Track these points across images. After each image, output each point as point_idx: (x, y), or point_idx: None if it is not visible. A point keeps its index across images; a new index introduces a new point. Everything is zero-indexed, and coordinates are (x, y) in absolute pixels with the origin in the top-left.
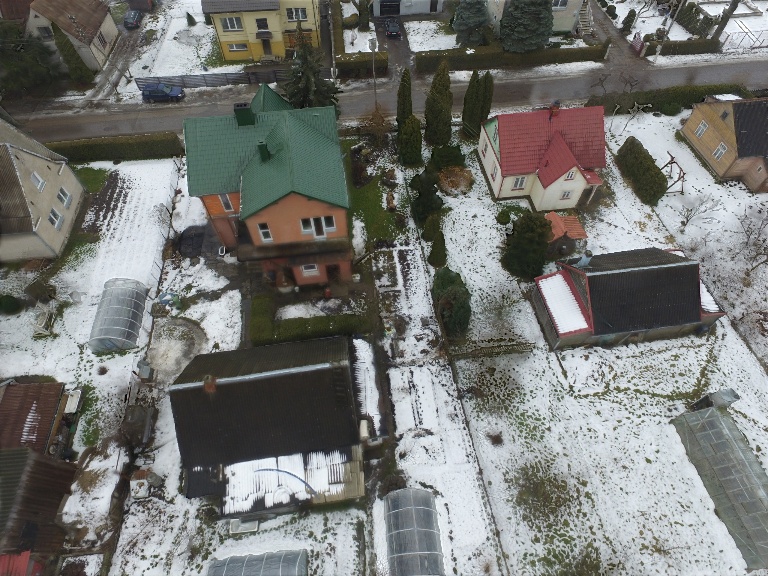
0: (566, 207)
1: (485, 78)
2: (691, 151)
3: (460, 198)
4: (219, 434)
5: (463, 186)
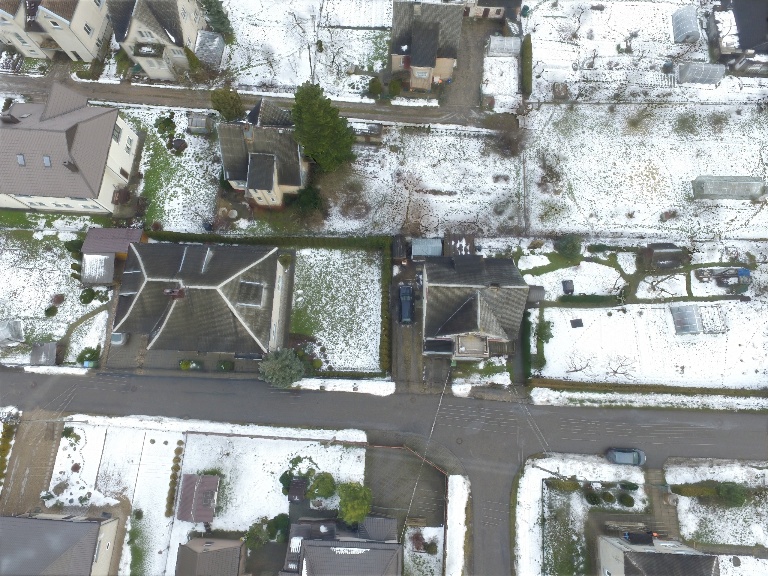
0: None
1: None
2: None
3: None
4: (748, 3)
5: None
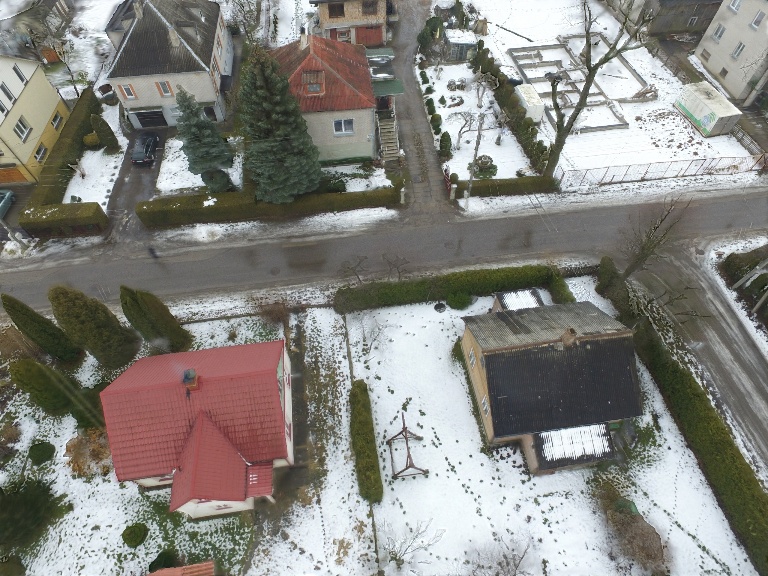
0: (238, 510)
1: (134, 300)
2: (466, 381)
3: (94, 484)
4: None
5: (110, 456)
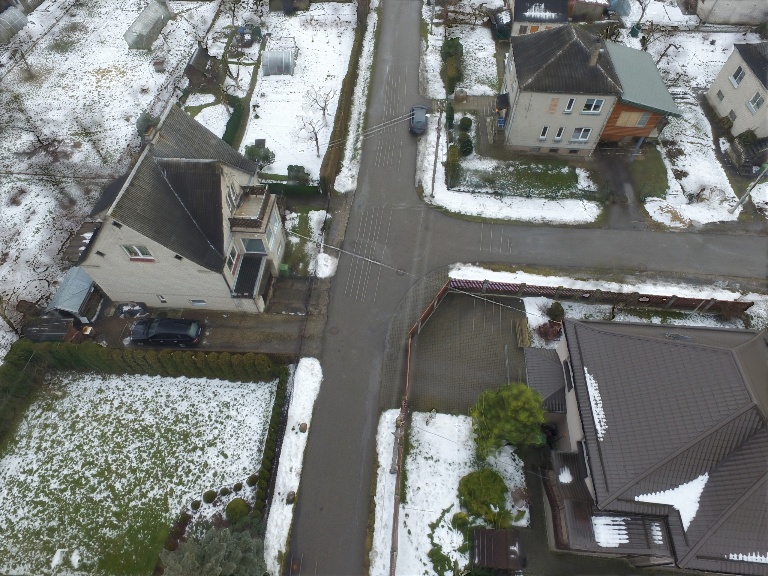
0: None
1: None
2: None
3: None
4: None
5: None
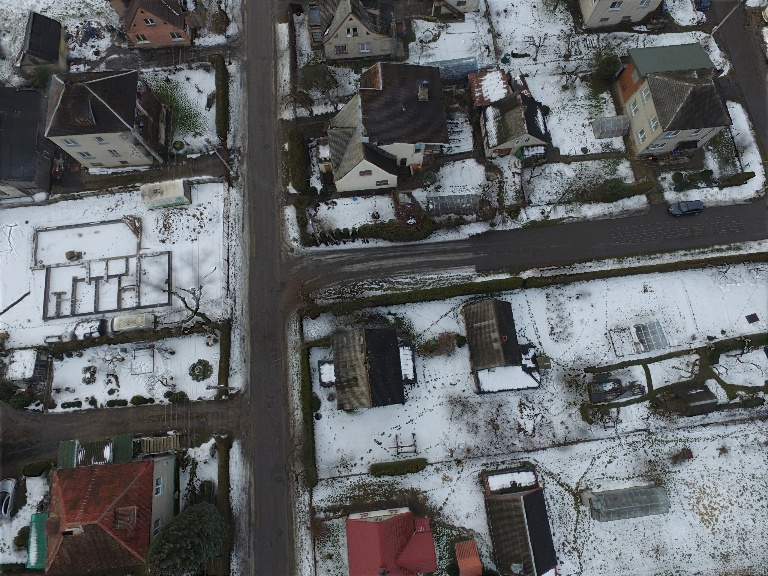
0: None
1: None
2: None
3: None
4: None
5: None
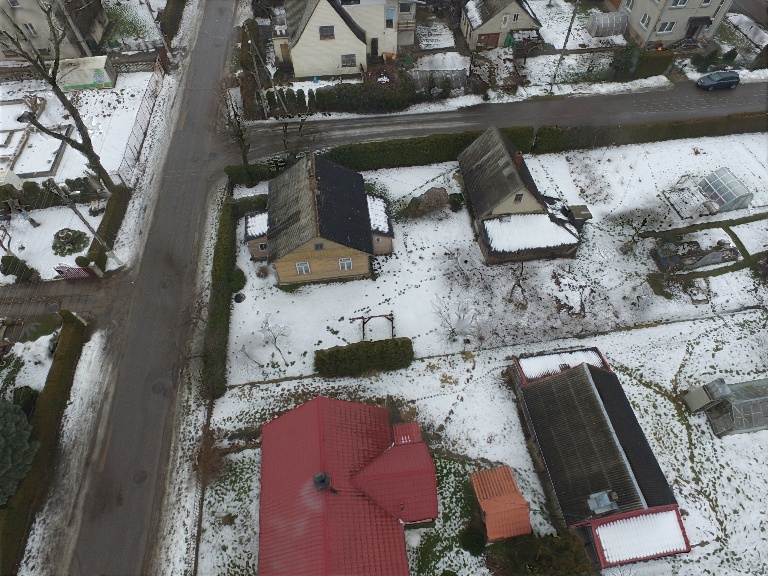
0: None
1: None
2: (317, 285)
3: None
4: None
5: None
